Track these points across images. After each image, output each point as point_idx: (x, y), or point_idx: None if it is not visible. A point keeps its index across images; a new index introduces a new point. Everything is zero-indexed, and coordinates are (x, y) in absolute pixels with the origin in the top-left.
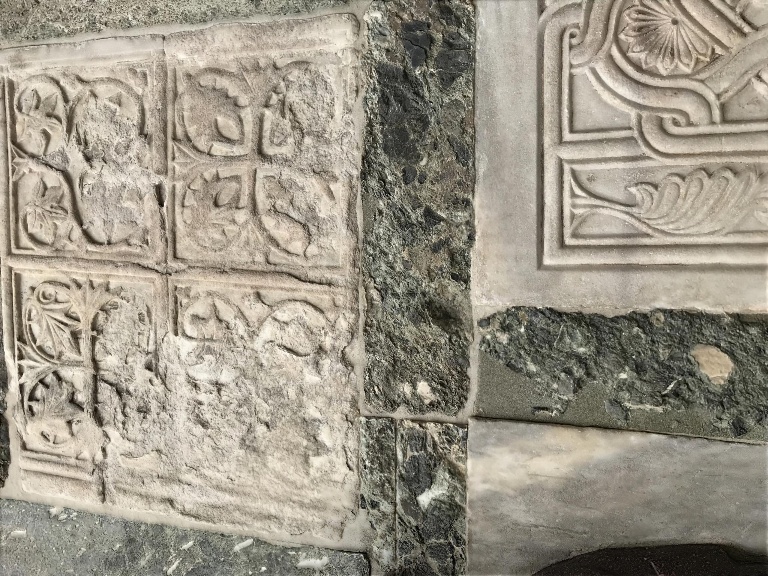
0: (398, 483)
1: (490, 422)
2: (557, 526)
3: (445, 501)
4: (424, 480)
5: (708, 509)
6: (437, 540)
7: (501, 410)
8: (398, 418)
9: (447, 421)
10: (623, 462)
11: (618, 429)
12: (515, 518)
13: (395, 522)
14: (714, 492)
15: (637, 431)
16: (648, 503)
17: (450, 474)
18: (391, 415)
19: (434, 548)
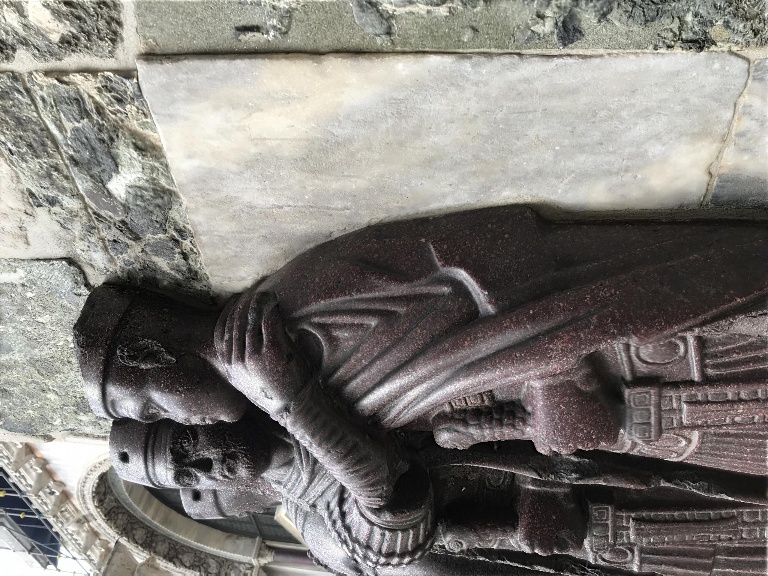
0: (70, 169)
1: (168, 63)
2: (308, 203)
3: (146, 186)
4: (105, 161)
5: (515, 160)
6: (154, 235)
7: (184, 38)
8: (23, 71)
9: (102, 68)
10: (389, 106)
11: (378, 52)
12: (248, 199)
13: (91, 218)
14: (525, 136)
15: (408, 53)
16: (430, 161)
17: (137, 150)
18: (9, 67)
19: (153, 245)
